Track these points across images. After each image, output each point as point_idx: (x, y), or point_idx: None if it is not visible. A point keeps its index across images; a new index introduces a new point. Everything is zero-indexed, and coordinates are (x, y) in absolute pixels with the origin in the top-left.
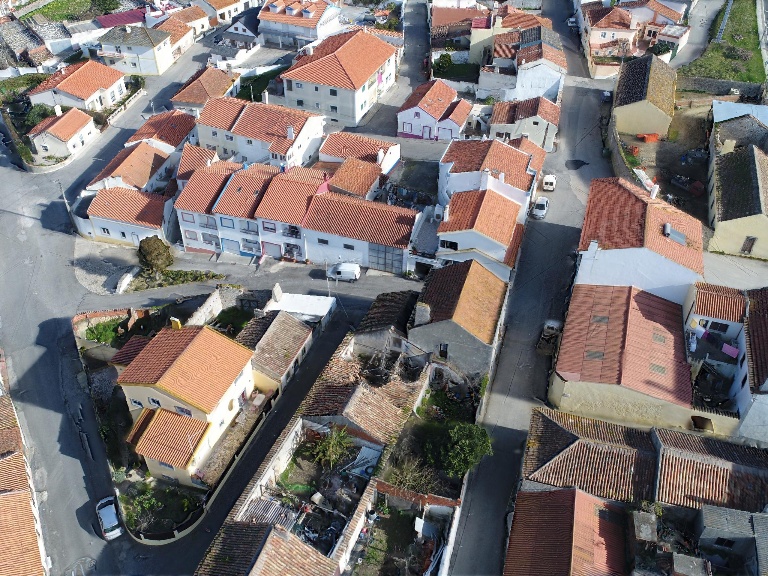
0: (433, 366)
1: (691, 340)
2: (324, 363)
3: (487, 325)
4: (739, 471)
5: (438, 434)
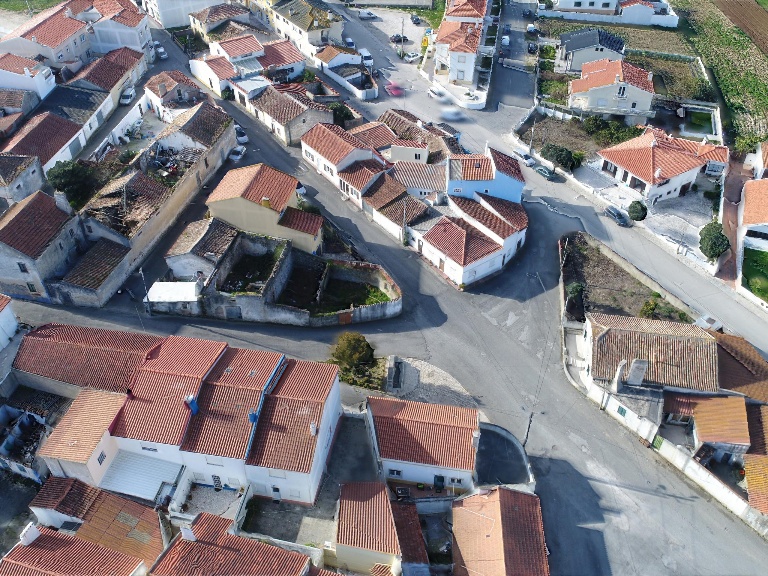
0: None
1: None
2: (162, 264)
3: None
4: None
5: (81, 178)
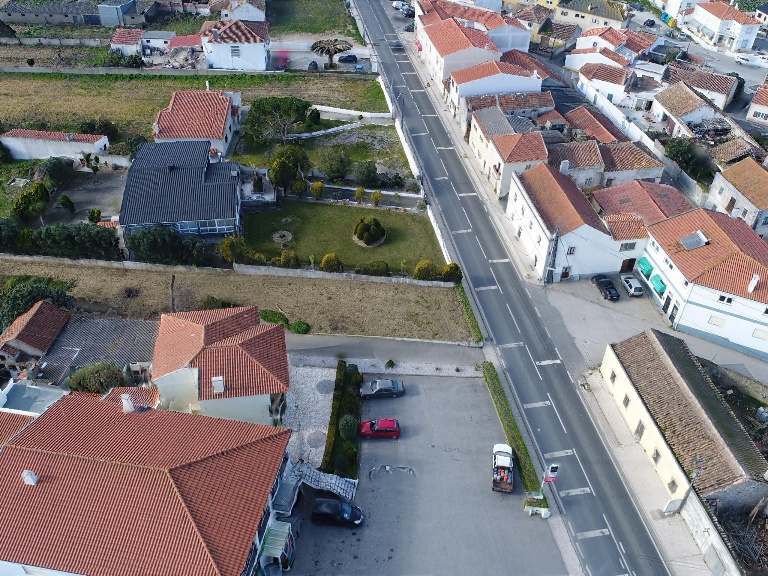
0: None
1: None
2: None
3: (735, 180)
4: None
5: (694, 152)
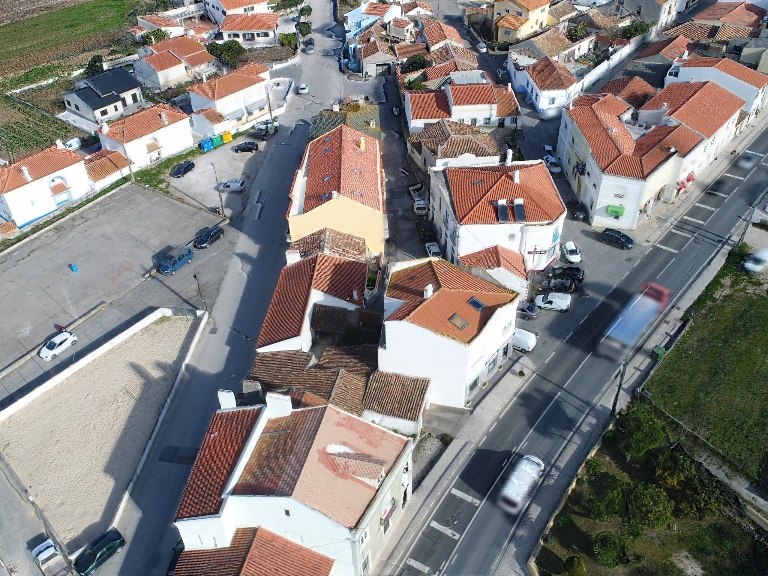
0: (633, 18)
1: (766, 16)
2: None
3: None
4: (755, 30)
5: None
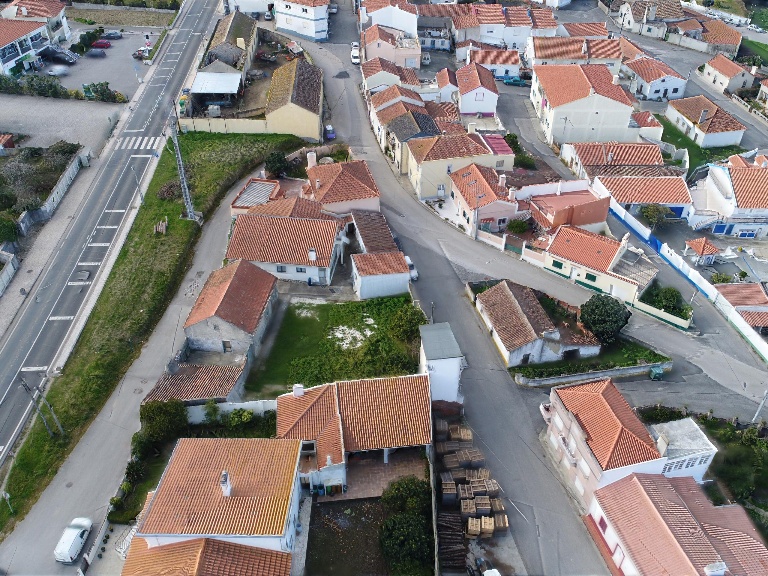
0: None
1: None
2: None
3: None
4: None
5: None
